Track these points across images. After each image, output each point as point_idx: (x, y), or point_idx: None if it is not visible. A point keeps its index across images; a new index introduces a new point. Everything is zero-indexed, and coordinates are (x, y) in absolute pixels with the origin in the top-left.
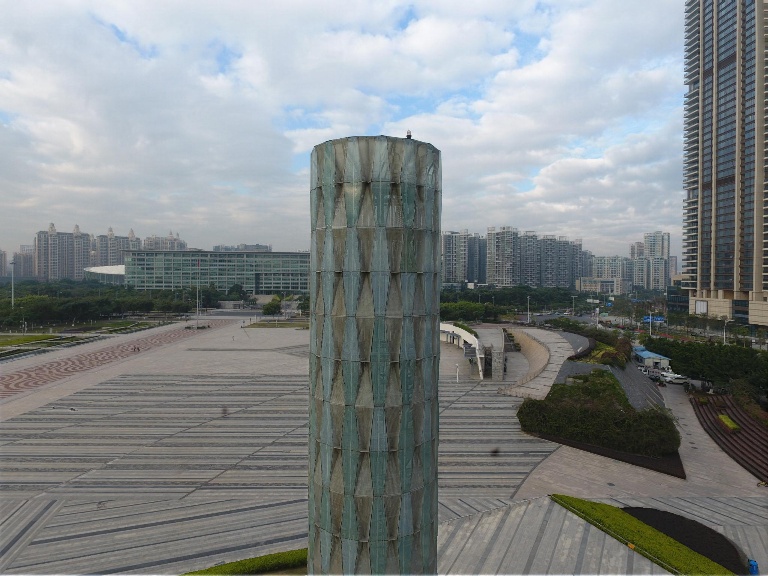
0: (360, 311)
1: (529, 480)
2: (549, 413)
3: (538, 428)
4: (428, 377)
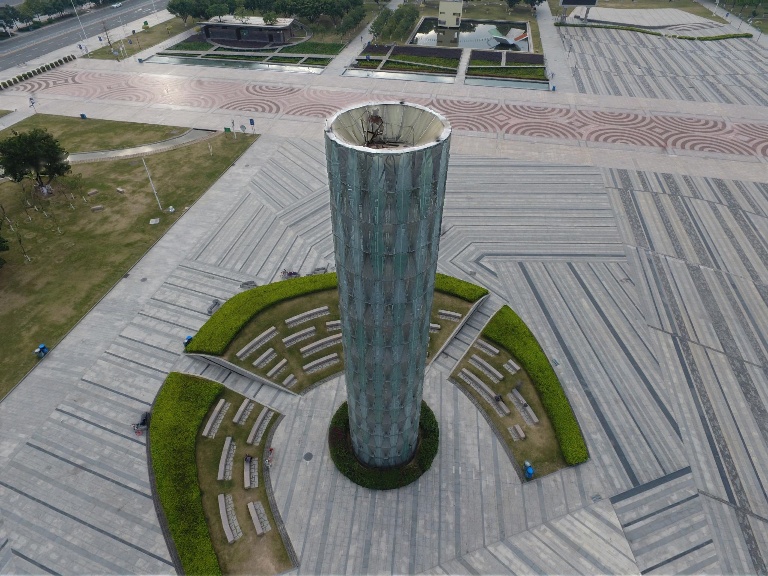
0: None
1: None
2: None
3: None
4: None
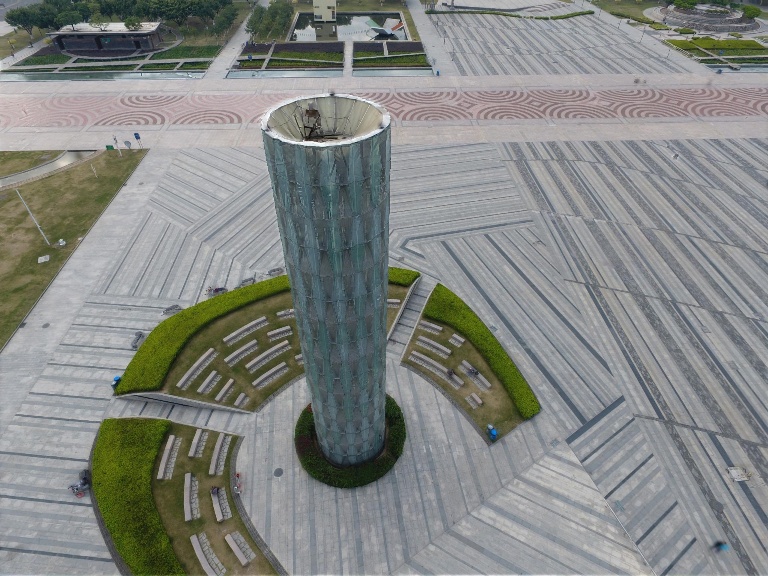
0: None
1: None
2: None
3: None
4: None
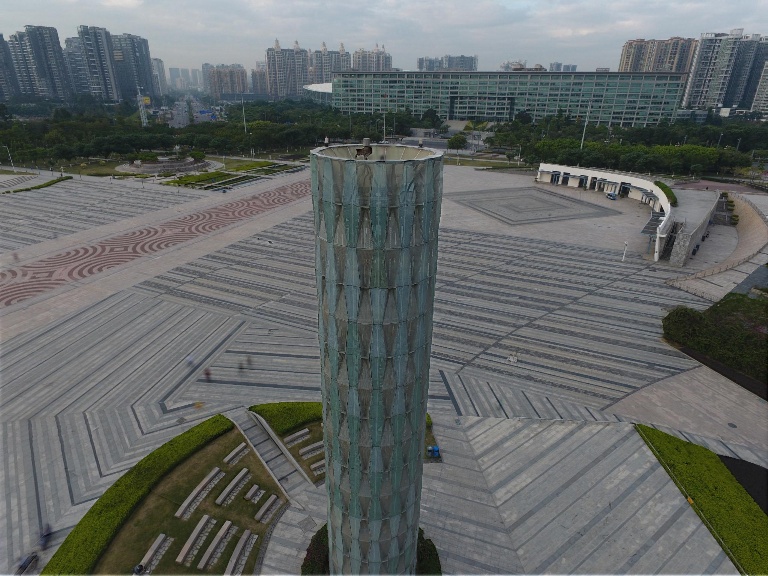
0: (338, 314)
1: (634, 396)
2: (702, 328)
3: (683, 340)
4: (403, 369)
